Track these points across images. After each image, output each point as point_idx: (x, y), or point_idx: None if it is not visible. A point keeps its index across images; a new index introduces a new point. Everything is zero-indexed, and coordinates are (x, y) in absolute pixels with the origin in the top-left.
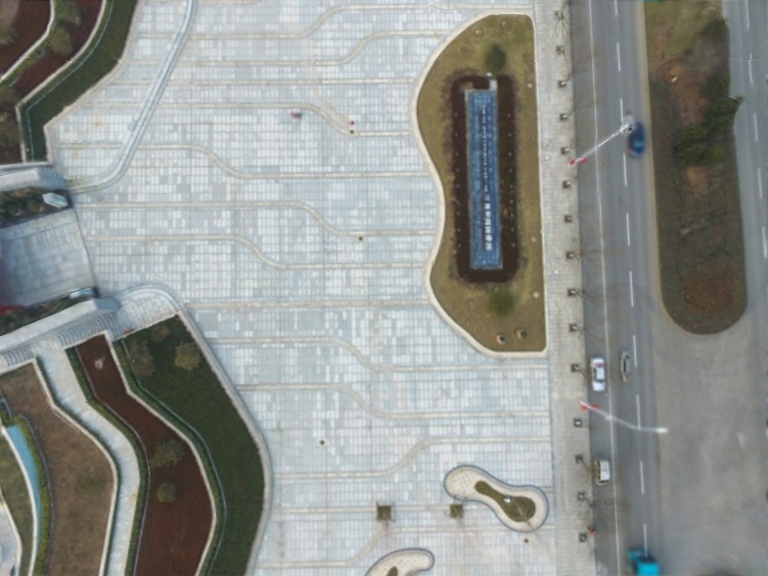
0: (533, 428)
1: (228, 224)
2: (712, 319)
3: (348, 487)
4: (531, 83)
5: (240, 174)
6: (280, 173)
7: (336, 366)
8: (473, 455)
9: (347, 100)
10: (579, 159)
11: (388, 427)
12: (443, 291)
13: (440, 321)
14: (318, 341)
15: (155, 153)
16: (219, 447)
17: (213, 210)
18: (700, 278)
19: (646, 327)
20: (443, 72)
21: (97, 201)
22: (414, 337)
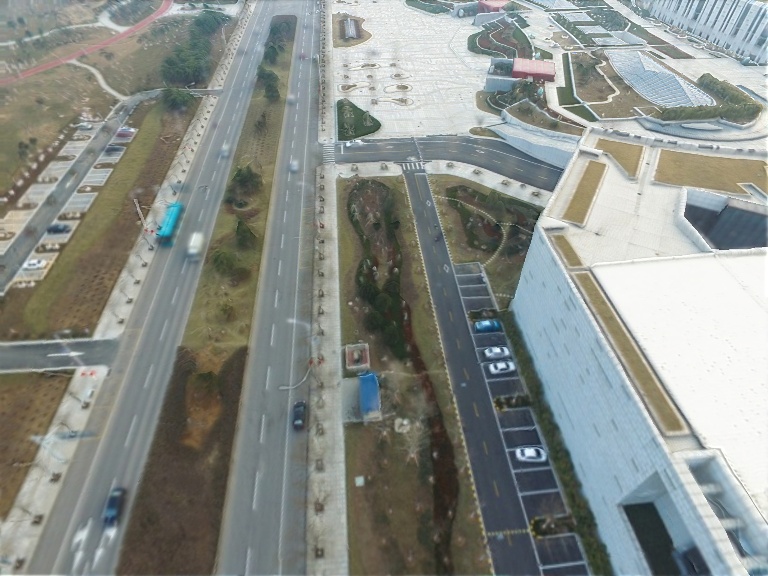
0: None
1: None
2: None
3: (384, 4)
4: None
5: None
6: None
7: None
8: (352, 6)
9: None
10: None
11: (375, 8)
12: None
13: None
14: None
15: None
16: (418, 4)
17: None
18: None
19: (303, 16)
20: None
21: None
22: (369, 15)
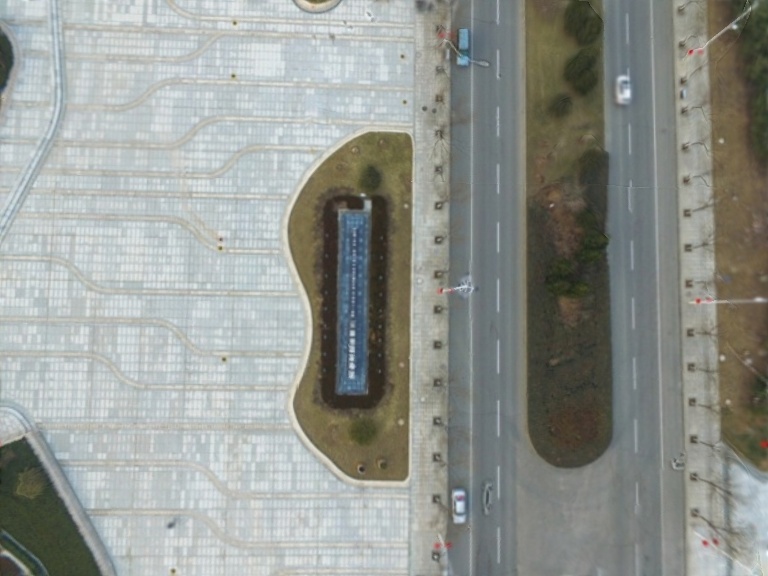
0: (391, 560)
1: (86, 341)
2: (576, 453)
3: None
4: (407, 203)
5: (101, 289)
6: (143, 289)
7: (192, 491)
8: None
9: (217, 215)
10: (446, 290)
11: (242, 556)
12: (306, 416)
13: (302, 447)
14: (174, 465)
15: (12, 264)
16: None
17: (71, 326)
18: (566, 411)
19: (511, 458)
20: (317, 190)
21: None
22: (274, 463)
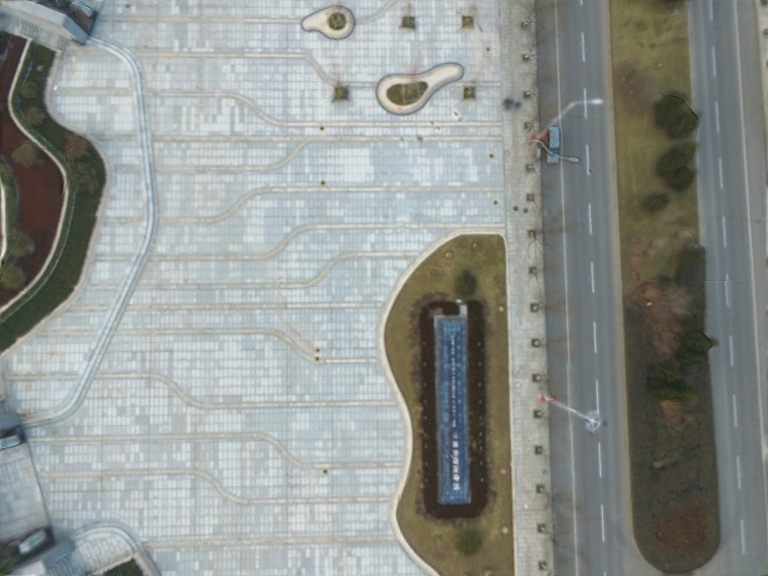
0: None
1: (188, 457)
2: (684, 558)
3: None
4: (502, 306)
5: (201, 404)
6: (242, 403)
7: None
8: None
9: (313, 325)
10: (549, 398)
11: None
12: (409, 527)
13: (406, 558)
14: None
15: (113, 383)
16: None
17: (172, 443)
18: (672, 515)
19: (617, 564)
20: (412, 296)
21: (51, 435)
22: (379, 575)
